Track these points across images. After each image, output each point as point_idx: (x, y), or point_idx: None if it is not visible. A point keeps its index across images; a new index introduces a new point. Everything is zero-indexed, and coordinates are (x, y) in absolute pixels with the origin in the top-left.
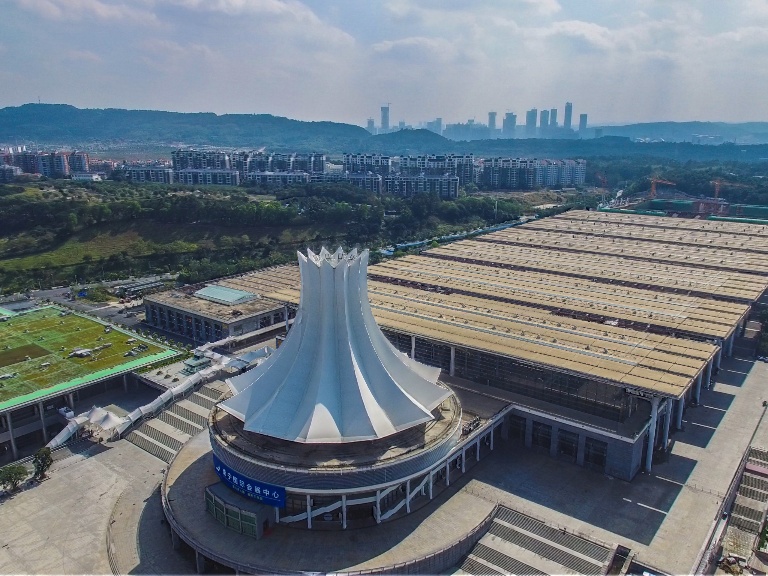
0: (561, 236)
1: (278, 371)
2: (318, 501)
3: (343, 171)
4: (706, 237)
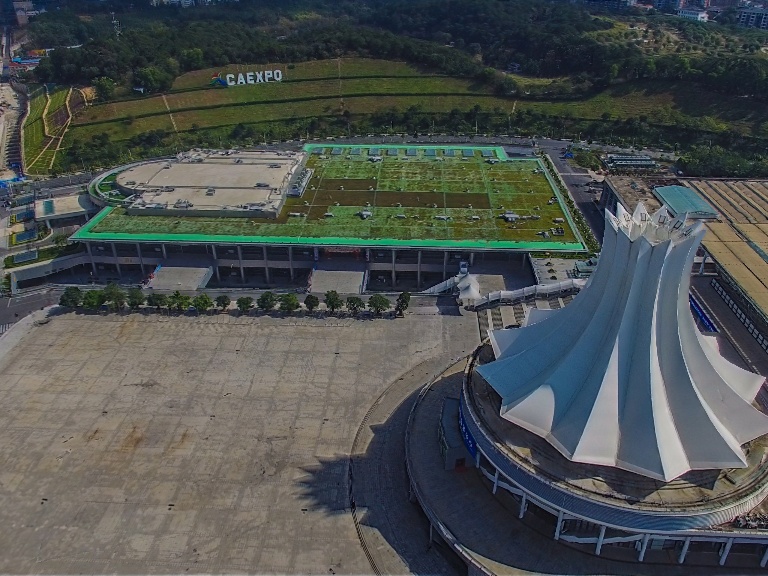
0: None
1: (551, 327)
2: None
3: None
4: None
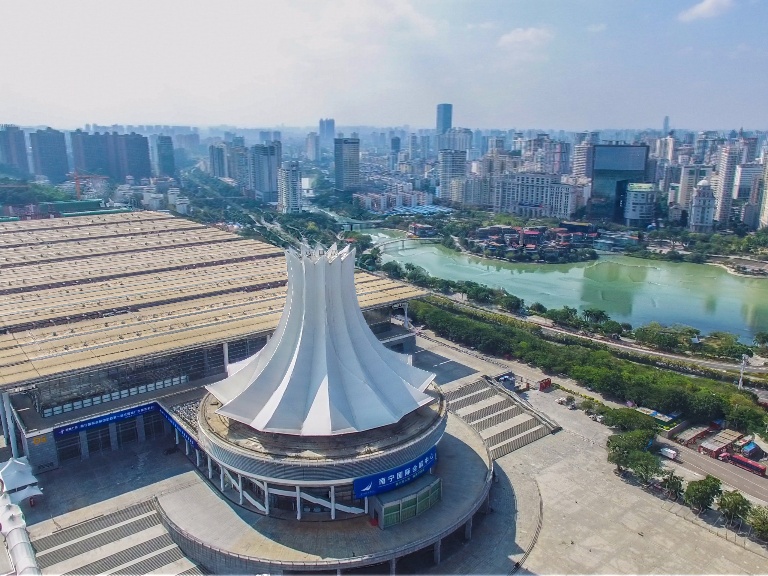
0: (16, 251)
1: None
2: None
3: None
4: (125, 227)
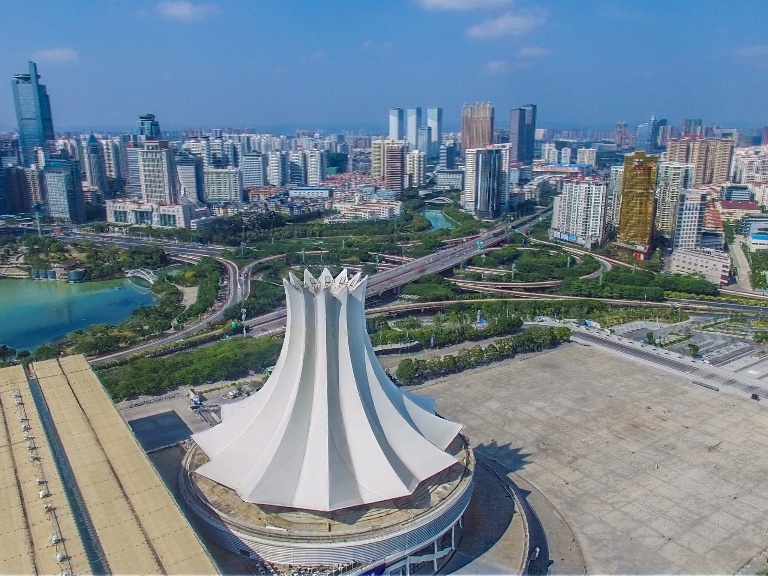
0: None
1: None
2: None
3: None
4: None
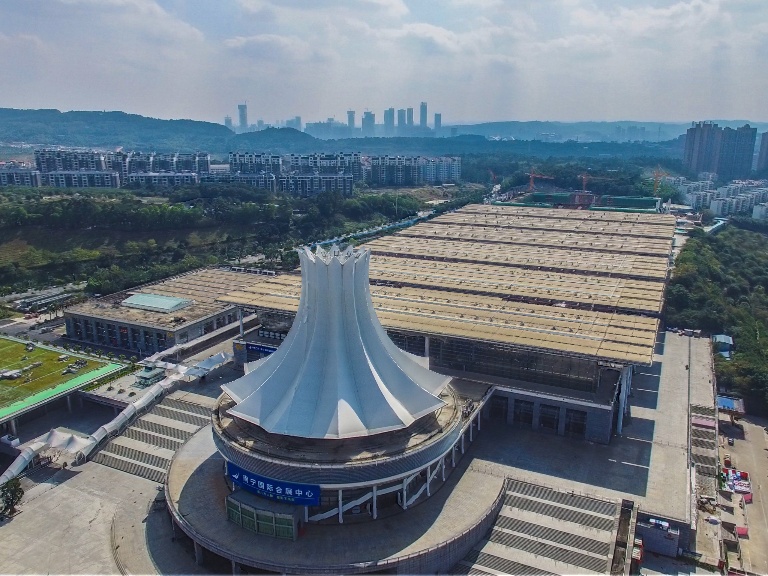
0: (473, 229)
1: (286, 372)
2: (347, 495)
3: (234, 171)
4: (597, 225)
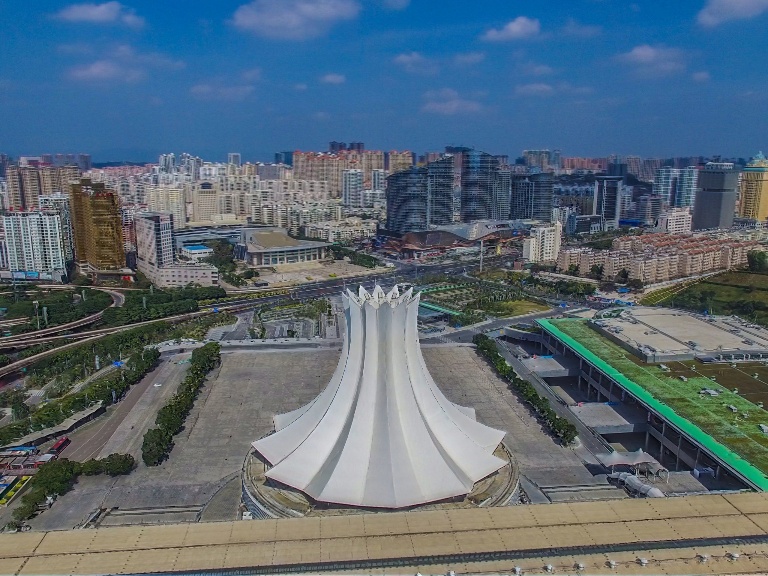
0: None
1: None
2: None
3: None
4: None
